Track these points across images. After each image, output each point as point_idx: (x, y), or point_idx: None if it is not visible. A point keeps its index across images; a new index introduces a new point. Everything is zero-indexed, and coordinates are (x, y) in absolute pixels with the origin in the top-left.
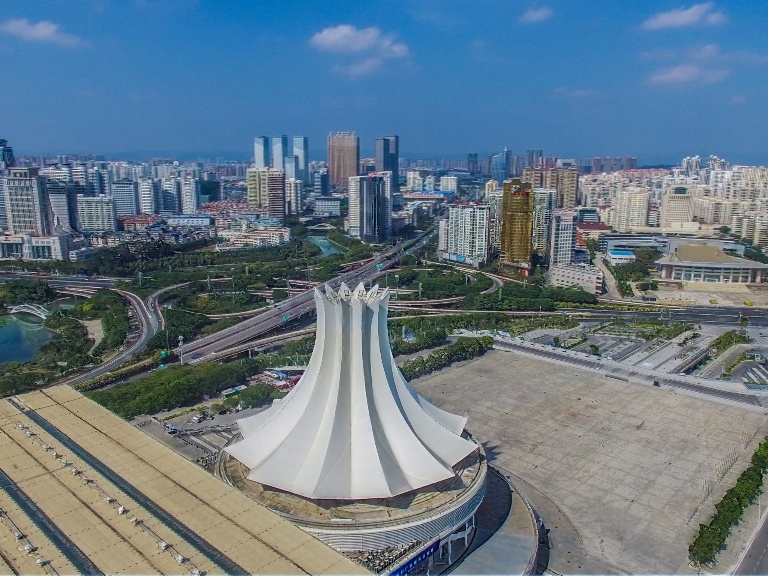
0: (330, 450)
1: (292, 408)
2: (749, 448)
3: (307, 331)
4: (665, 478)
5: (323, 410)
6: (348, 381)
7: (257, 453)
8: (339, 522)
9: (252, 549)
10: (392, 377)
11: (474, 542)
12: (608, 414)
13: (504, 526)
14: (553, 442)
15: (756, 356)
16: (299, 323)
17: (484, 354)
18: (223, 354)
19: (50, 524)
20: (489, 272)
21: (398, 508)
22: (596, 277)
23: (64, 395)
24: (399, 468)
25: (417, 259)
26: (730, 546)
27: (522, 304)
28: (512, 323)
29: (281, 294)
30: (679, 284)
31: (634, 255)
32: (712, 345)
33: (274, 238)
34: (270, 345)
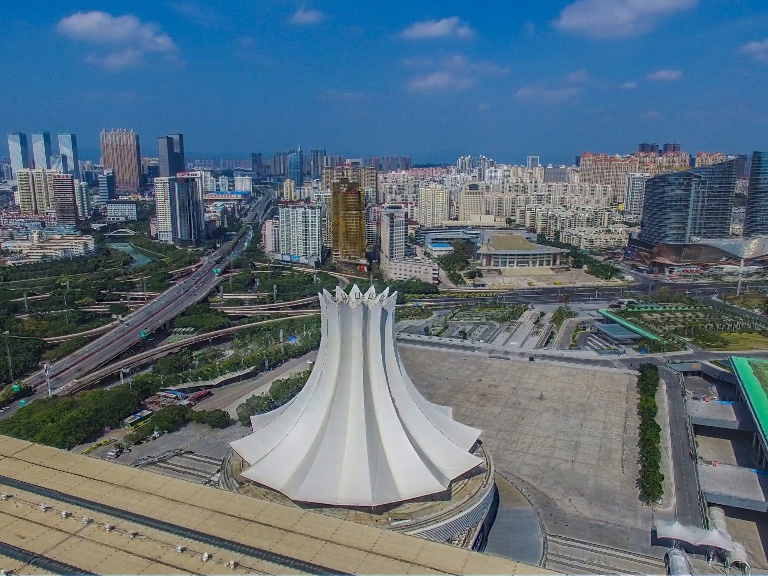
0: (370, 456)
1: (307, 420)
2: (630, 403)
3: (172, 345)
4: (585, 438)
5: (346, 417)
6: (369, 384)
7: (280, 473)
8: (401, 524)
9: (378, 564)
10: None
11: (486, 521)
12: (511, 390)
13: (501, 502)
14: (481, 422)
15: (587, 327)
16: (155, 338)
17: None
18: (87, 380)
19: None
20: (328, 270)
21: (443, 501)
22: (432, 269)
23: (4, 446)
24: (431, 462)
25: (250, 262)
26: (662, 484)
27: None
28: None
29: (121, 308)
30: (498, 270)
31: (452, 247)
32: (551, 321)
33: (77, 247)
34: (134, 364)
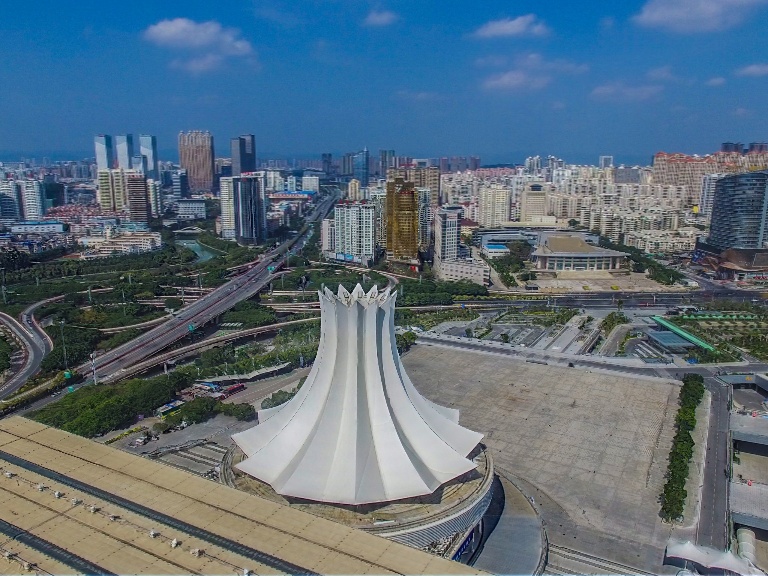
0: (359, 454)
1: (303, 416)
2: (668, 414)
3: (218, 339)
4: (613, 448)
5: (340, 415)
6: (364, 383)
7: (273, 466)
8: (383, 525)
9: (338, 562)
10: (400, 376)
11: (485, 528)
12: (543, 396)
13: (506, 509)
14: (506, 427)
15: (638, 334)
16: (204, 331)
17: (409, 349)
18: (134, 370)
19: (98, 569)
20: (380, 270)
21: (432, 504)
22: (483, 270)
23: (23, 428)
24: (424, 465)
25: (305, 260)
26: (687, 501)
27: (423, 299)
28: (420, 318)
29: (175, 302)
30: (553, 273)
31: (508, 248)
32: (601, 327)
33: (145, 243)
34: (180, 357)
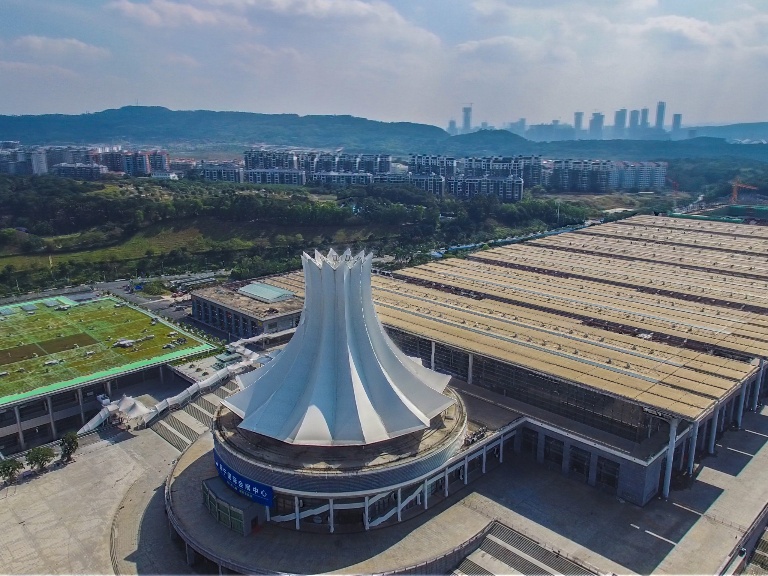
0: None
1: None
2: None
3: None
4: None
5: None
6: None
7: None
8: None
9: None
10: None
11: None
12: None
13: None
14: None
15: None
16: None
17: None
18: None
19: None
20: None
21: None
22: None
23: (663, 401)
24: None
25: None
26: None
27: None
28: None
29: None
30: None
31: None
32: None
33: None
34: None
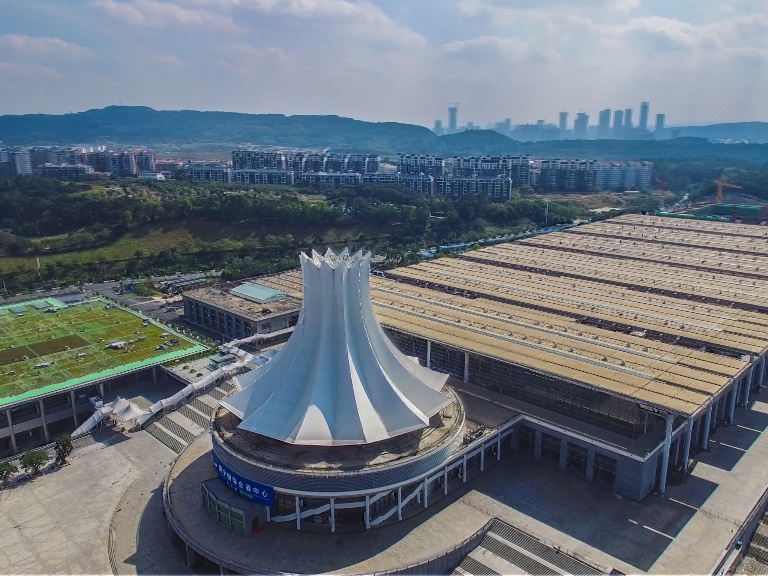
0: None
1: None
2: None
3: None
4: None
5: None
6: None
7: None
8: None
9: (395, 315)
10: None
11: None
12: None
13: None
14: None
15: None
16: None
17: None
18: None
19: None
20: None
21: None
22: None
23: (659, 398)
24: None
25: None
26: None
27: None
28: None
29: None
30: None
31: None
32: None
33: None
34: None
